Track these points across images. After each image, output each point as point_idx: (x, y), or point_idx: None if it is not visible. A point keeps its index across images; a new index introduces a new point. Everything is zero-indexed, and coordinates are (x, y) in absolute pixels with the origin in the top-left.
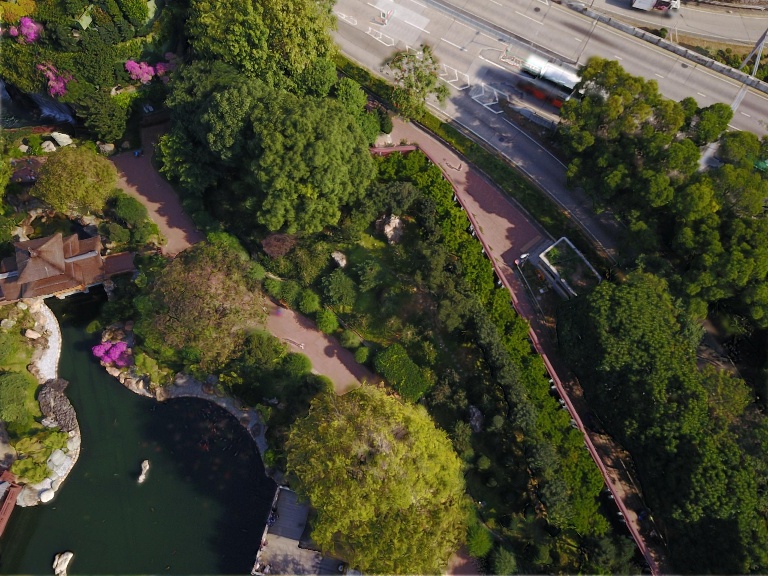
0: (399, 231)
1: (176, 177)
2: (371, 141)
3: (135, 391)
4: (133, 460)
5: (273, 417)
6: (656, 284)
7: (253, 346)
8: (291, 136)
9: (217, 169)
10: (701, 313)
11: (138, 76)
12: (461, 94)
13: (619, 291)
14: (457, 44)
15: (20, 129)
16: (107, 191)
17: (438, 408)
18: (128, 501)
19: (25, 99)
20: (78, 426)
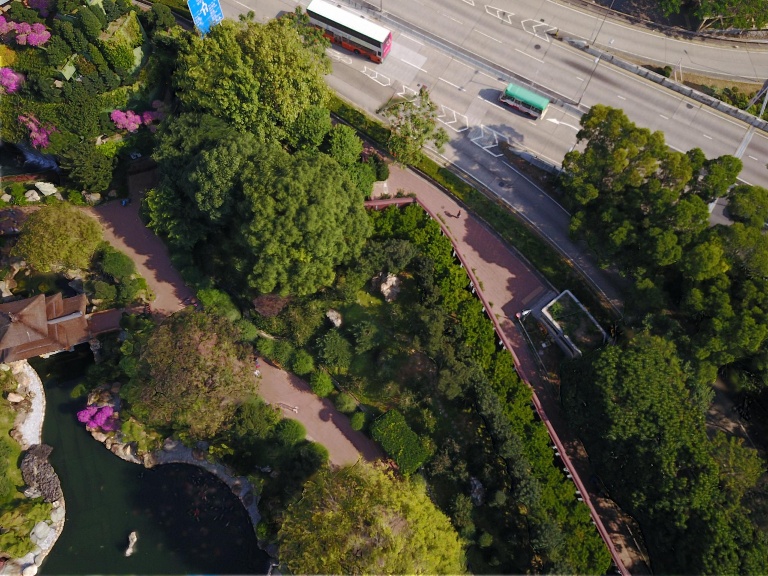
0: (396, 289)
1: (164, 232)
2: (367, 194)
3: (122, 457)
4: (120, 531)
5: (266, 486)
6: (664, 348)
7: (244, 416)
8: (283, 200)
9: (207, 224)
10: (711, 377)
11: (124, 126)
12: (460, 136)
13: (626, 358)
14: (455, 84)
15: (3, 178)
16: (92, 250)
17: (438, 479)
18: (115, 575)
19: (8, 146)
20: (63, 496)
